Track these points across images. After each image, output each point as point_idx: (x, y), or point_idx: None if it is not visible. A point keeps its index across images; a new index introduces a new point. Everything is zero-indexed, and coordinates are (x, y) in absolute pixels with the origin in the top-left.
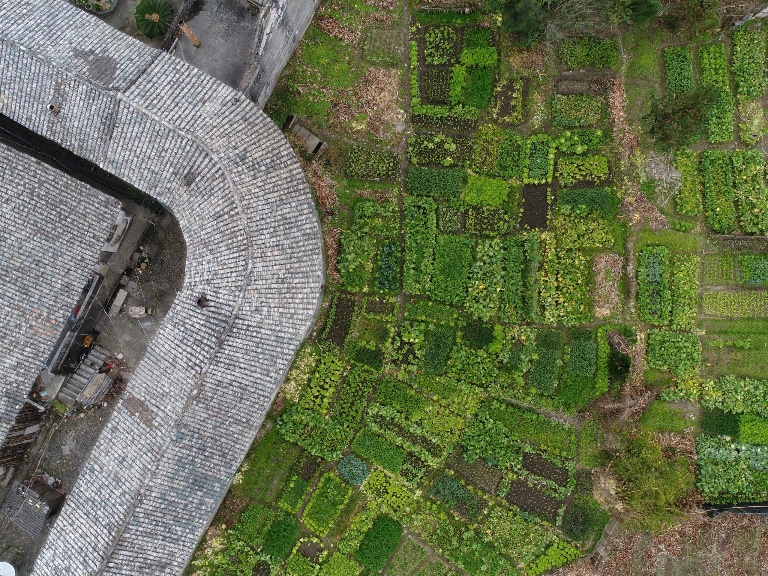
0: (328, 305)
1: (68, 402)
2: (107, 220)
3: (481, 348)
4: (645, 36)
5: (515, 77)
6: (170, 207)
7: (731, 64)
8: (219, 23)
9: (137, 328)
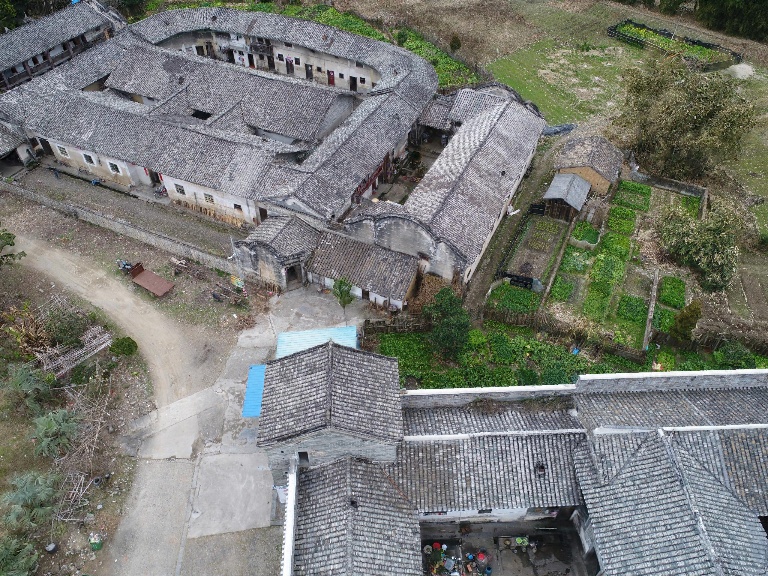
0: None
1: None
2: None
3: None
4: (151, 0)
5: None
6: (176, 33)
7: None
8: None
9: None
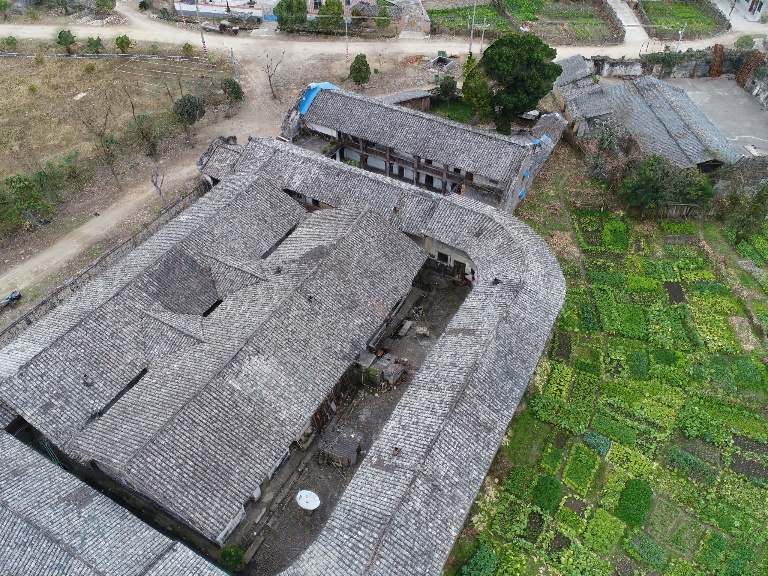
0: (552, 338)
1: (377, 372)
2: (421, 260)
3: (670, 366)
4: (707, 224)
5: (639, 235)
6: (463, 251)
7: (763, 236)
8: (472, 198)
9: (417, 345)
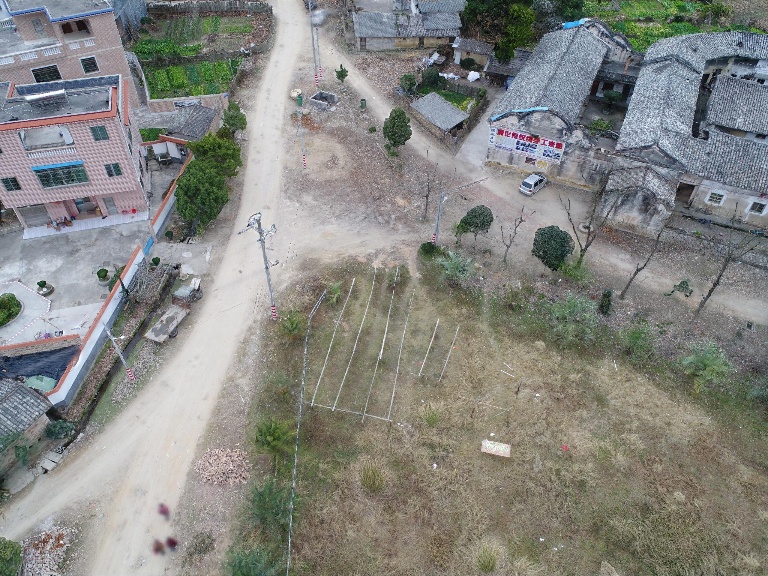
0: None
1: None
2: None
3: None
4: None
5: None
6: None
7: None
8: None
9: None
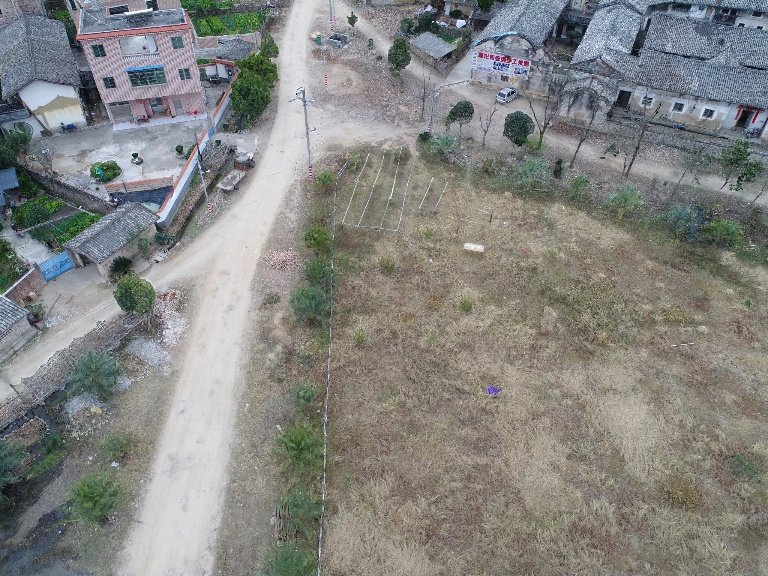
0: None
1: None
2: None
3: None
4: None
5: None
6: None
7: None
8: None
9: None
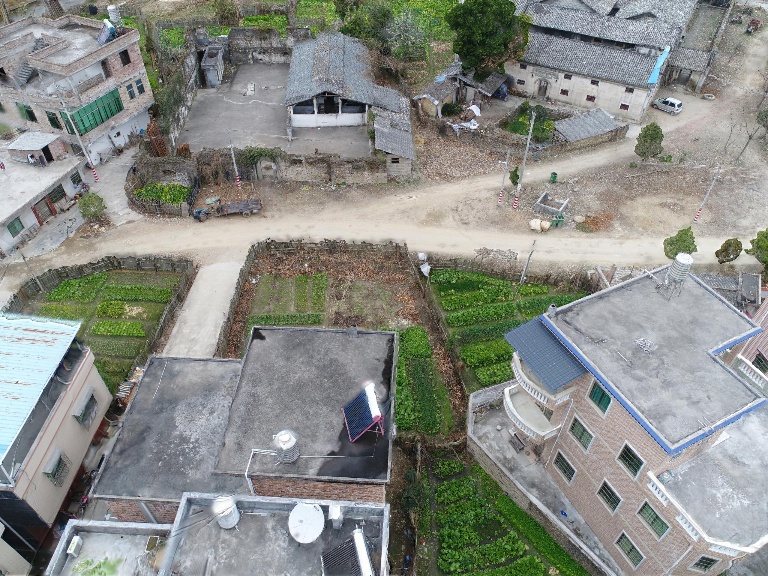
0: None
1: None
2: None
3: None
4: None
5: None
6: None
7: None
8: None
9: None
